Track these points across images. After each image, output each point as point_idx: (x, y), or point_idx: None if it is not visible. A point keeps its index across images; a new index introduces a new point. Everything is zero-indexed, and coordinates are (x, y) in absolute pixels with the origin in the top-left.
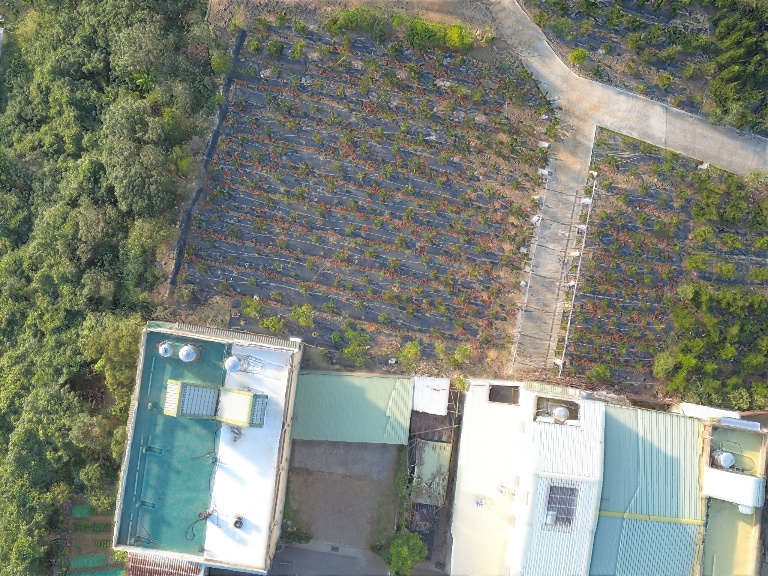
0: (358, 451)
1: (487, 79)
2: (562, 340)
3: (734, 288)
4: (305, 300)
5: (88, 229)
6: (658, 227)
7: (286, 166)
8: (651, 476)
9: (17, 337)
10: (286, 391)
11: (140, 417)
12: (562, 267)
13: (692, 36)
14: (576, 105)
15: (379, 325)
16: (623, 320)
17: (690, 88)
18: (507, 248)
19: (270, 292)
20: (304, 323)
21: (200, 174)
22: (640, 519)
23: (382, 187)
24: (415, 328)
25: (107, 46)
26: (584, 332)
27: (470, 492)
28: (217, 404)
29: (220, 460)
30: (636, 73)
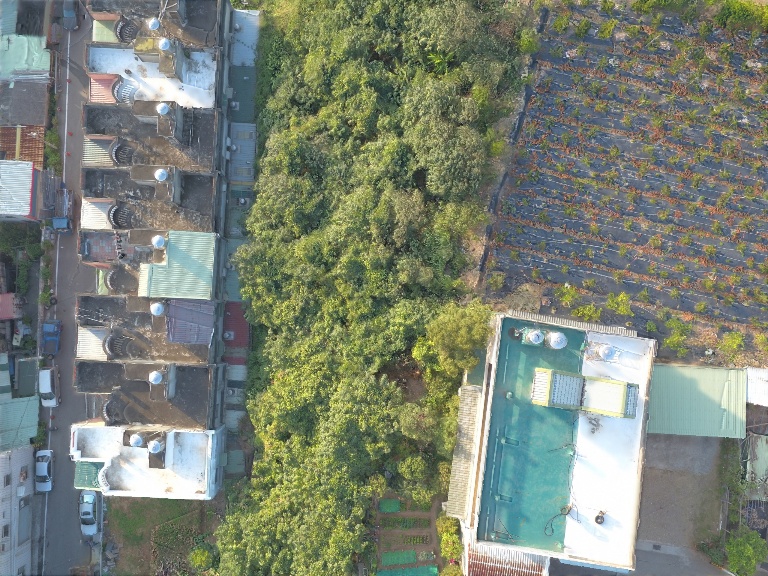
0: (679, 445)
1: None
2: None
3: None
4: (618, 288)
5: (406, 213)
6: None
7: (595, 149)
8: None
9: (310, 326)
10: (650, 381)
11: (495, 407)
12: None
13: None
14: None
15: (694, 315)
16: None
17: None
18: None
19: (582, 280)
20: (625, 312)
21: (512, 157)
22: None
23: (694, 171)
24: (732, 318)
25: (398, 26)
26: None
27: None
28: (582, 394)
29: (578, 452)
30: None
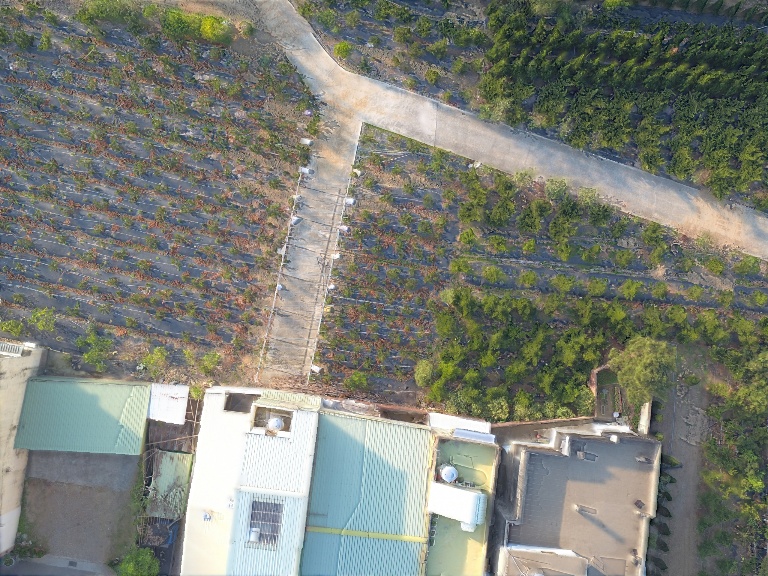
0: (99, 461)
1: (249, 73)
2: (320, 346)
3: (504, 293)
4: (49, 303)
5: None
6: (420, 228)
7: (33, 162)
8: (374, 490)
9: None
10: None
11: None
12: (322, 270)
13: (462, 29)
14: (342, 100)
15: (128, 329)
16: (385, 325)
17: (463, 84)
18: (264, 249)
19: (13, 294)
20: (41, 327)
21: None
22: (359, 536)
23: (134, 185)
24: (165, 333)
25: None
26: (344, 338)
27: (196, 506)
28: None
29: None
30: (406, 67)
